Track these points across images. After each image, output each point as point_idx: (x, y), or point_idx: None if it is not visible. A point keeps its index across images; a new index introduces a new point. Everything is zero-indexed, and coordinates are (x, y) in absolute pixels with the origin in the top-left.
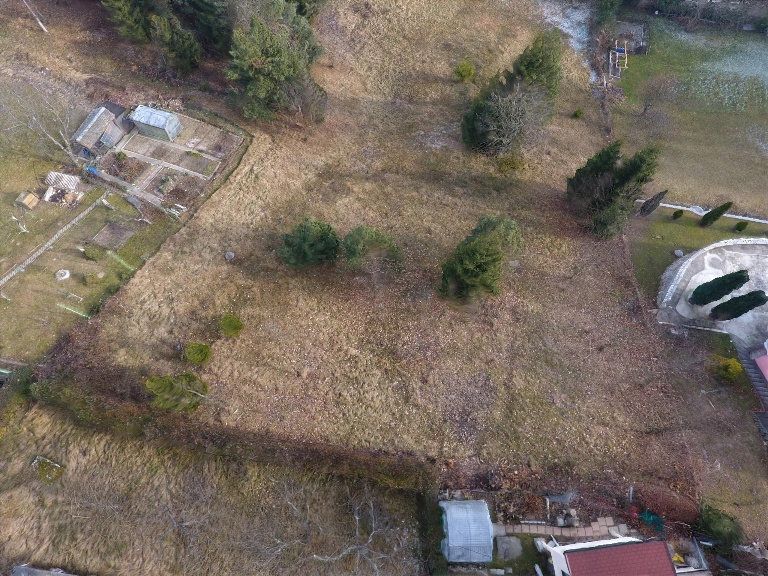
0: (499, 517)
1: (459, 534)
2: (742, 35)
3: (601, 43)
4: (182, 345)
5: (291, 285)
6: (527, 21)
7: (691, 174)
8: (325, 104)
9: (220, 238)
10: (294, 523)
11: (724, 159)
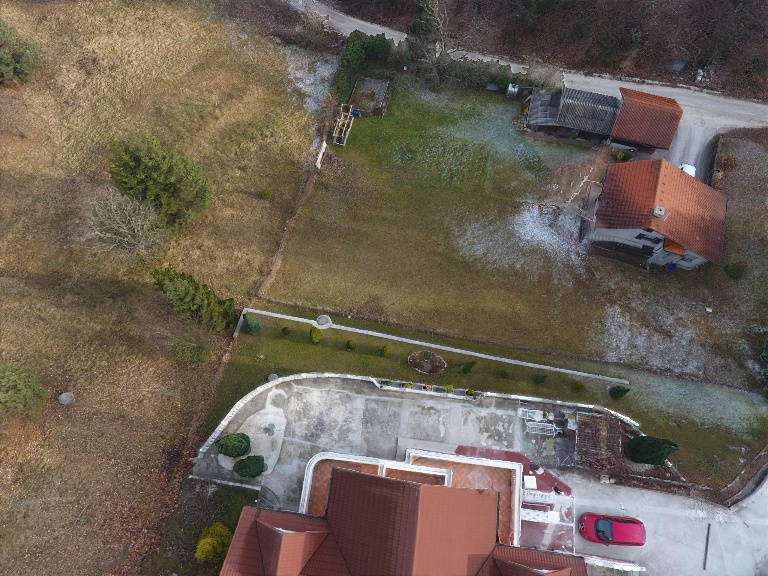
0: None
1: None
2: (484, 96)
3: (329, 106)
4: None
5: None
6: (266, 78)
7: (359, 268)
8: None
9: None
10: None
11: (407, 247)
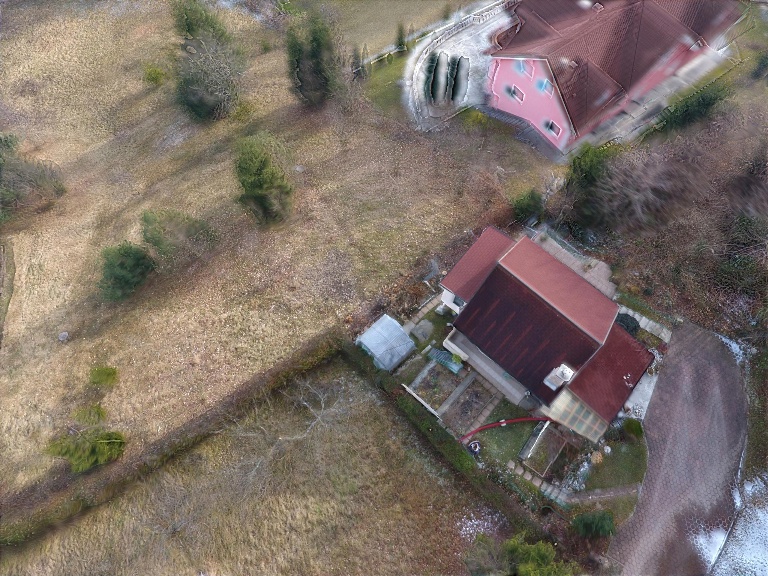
0: (403, 318)
1: (378, 344)
2: None
3: None
4: (72, 427)
5: (137, 314)
6: (188, 6)
7: (384, 32)
8: (61, 173)
9: (44, 332)
10: (265, 453)
11: (399, 8)
